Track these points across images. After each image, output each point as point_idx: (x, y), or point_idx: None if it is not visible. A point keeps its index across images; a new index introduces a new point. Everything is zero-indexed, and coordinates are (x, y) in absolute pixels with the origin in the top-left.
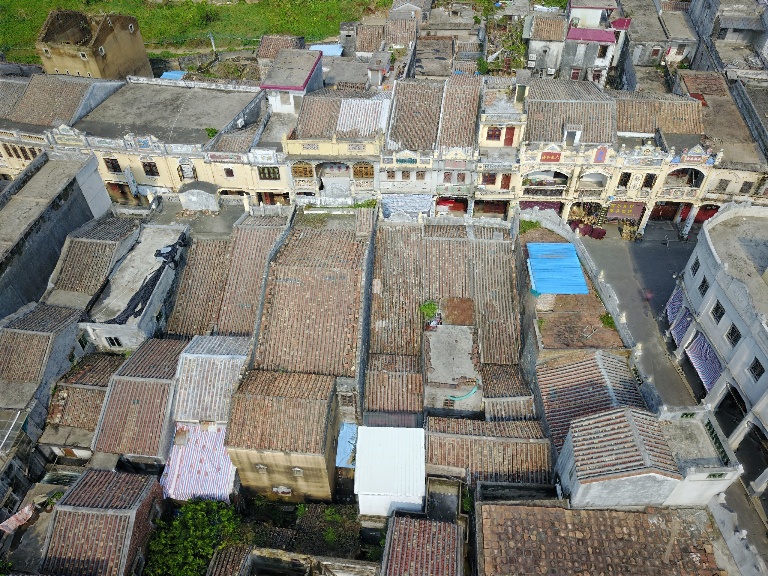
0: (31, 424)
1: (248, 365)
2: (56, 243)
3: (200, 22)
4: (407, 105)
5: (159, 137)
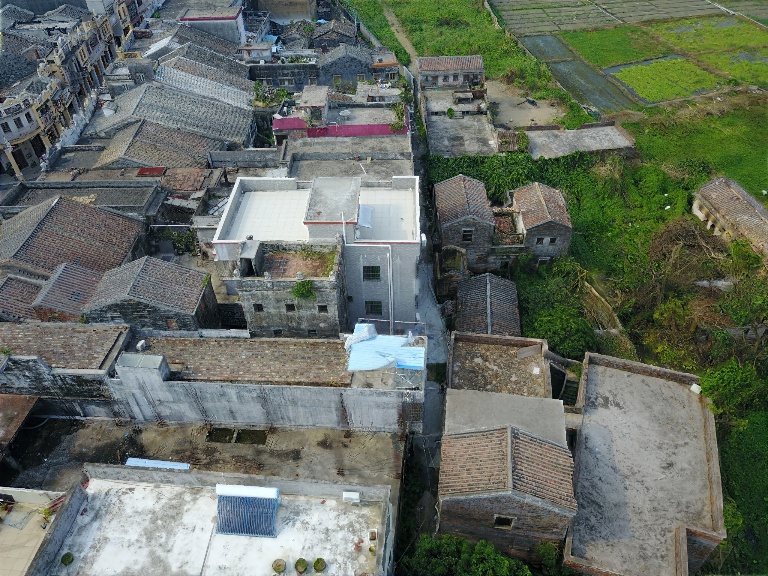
0: None
1: None
2: (57, 1)
3: (436, 20)
4: None
5: (170, 11)
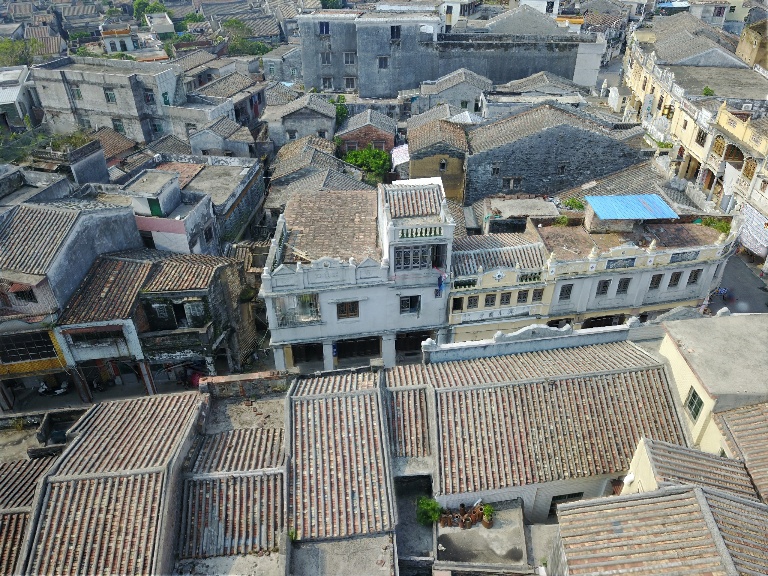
0: (417, 103)
1: (464, 125)
2: (533, 67)
3: None
4: None
5: (689, 87)
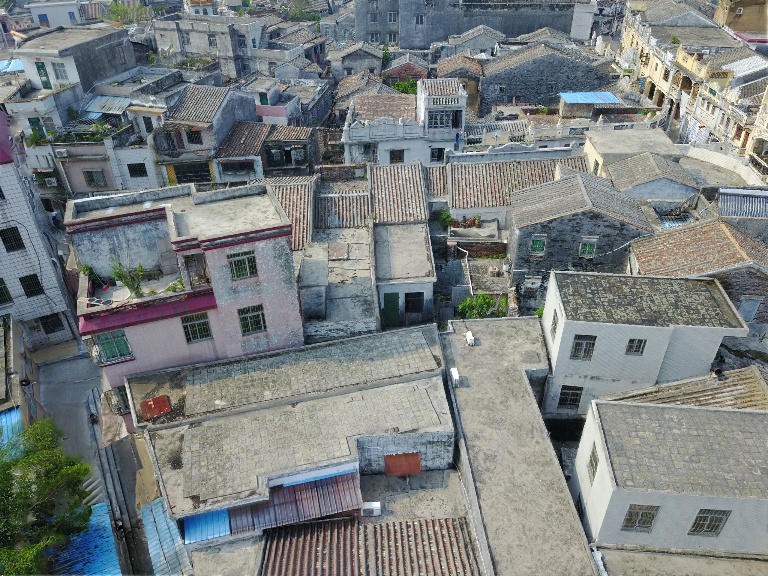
0: (445, 51)
1: (481, 60)
2: (538, 24)
3: None
4: None
5: None
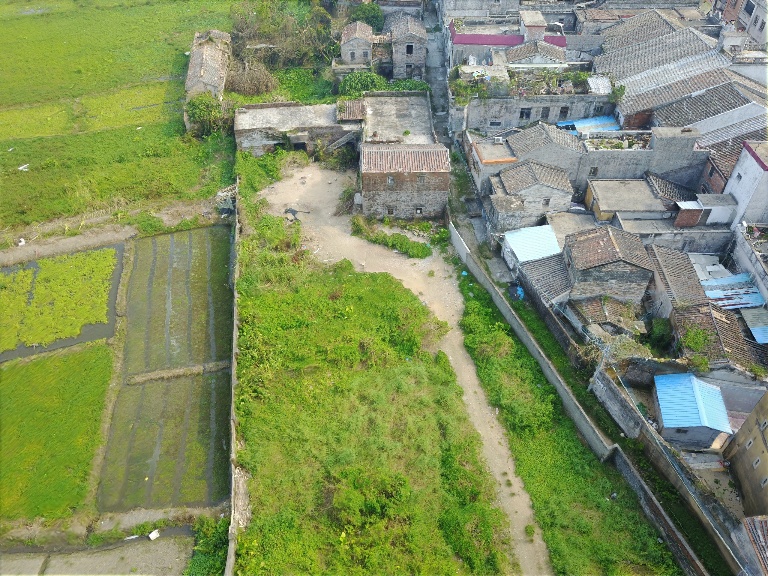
0: None
1: None
2: None
3: None
4: (766, 106)
5: None
